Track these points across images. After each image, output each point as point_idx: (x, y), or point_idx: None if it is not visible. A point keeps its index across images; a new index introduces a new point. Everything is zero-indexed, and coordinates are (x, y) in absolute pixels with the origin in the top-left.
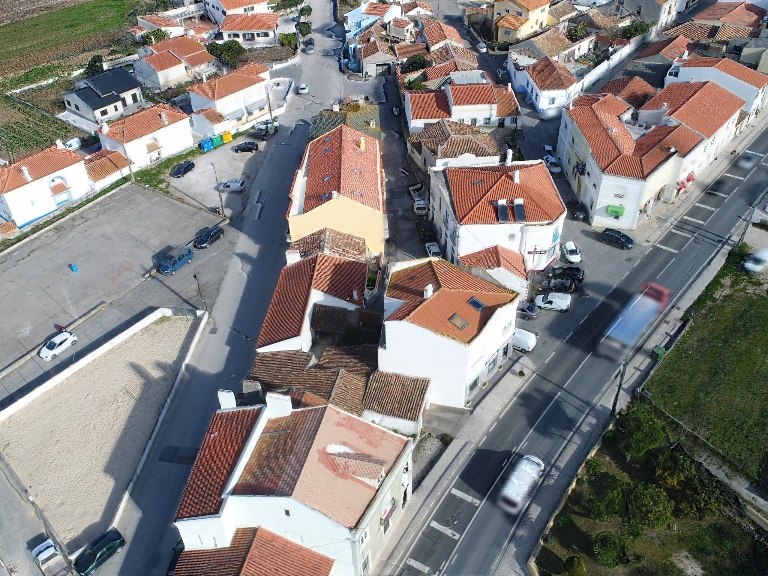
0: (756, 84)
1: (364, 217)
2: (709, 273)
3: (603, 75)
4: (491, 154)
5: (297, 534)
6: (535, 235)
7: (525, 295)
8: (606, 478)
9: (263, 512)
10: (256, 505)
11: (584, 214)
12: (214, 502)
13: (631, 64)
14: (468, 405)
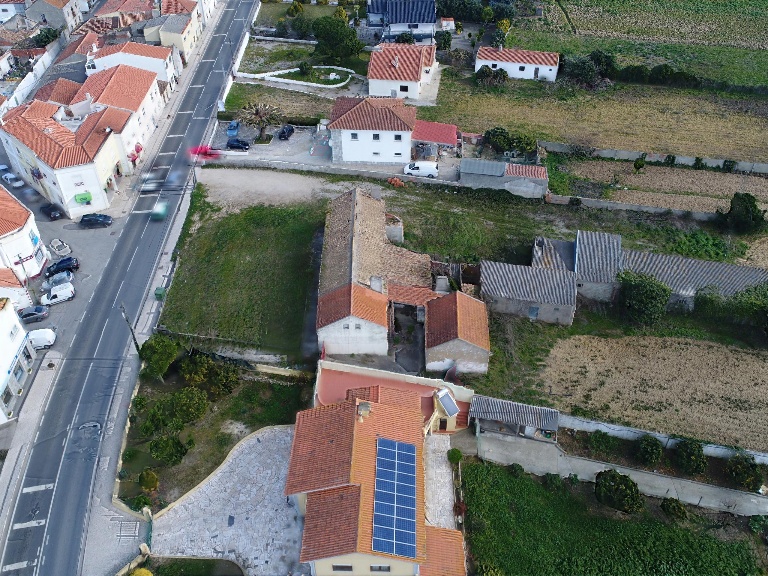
0: (161, 57)
1: None
2: (181, 217)
3: (34, 86)
4: None
5: None
6: (11, 245)
7: (29, 301)
8: (153, 405)
9: None
10: None
11: (59, 212)
12: None
13: (54, 69)
14: (11, 416)
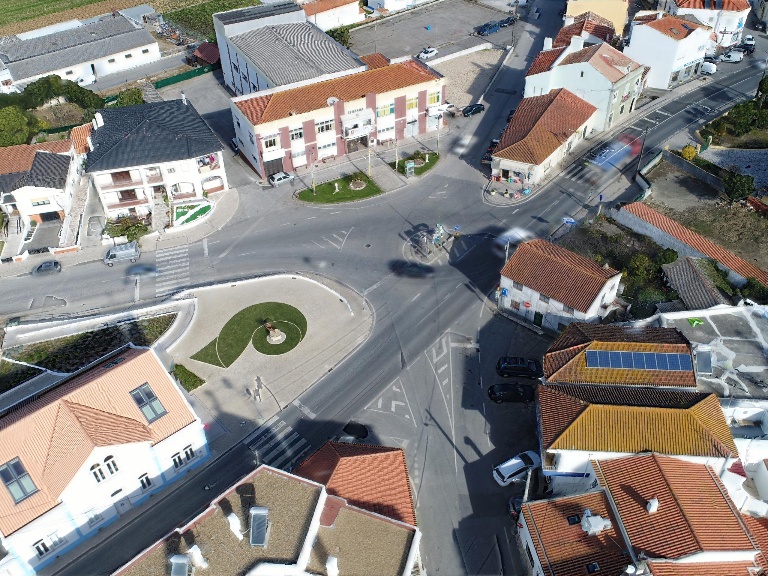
0: None
1: (616, 6)
2: None
3: None
4: None
5: (583, 90)
6: (727, 18)
7: (713, 53)
8: None
9: (569, 76)
10: (567, 71)
11: (763, 26)
12: (546, 69)
13: None
14: (670, 87)
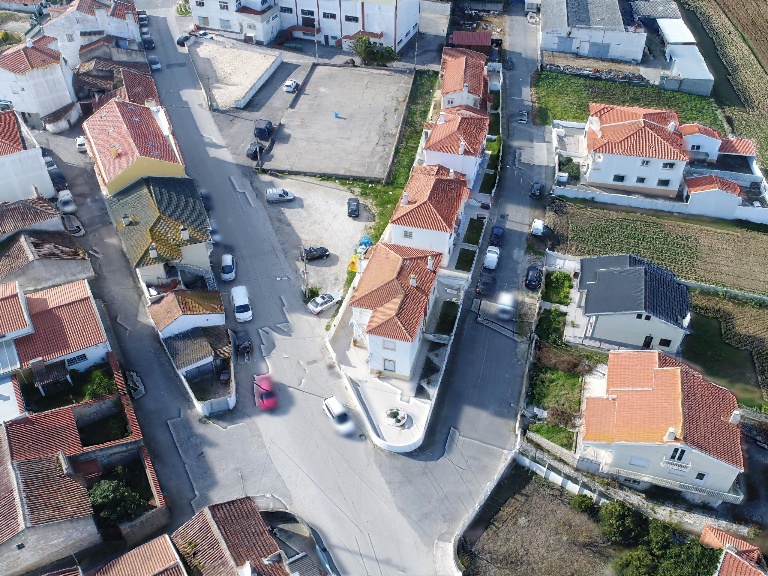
0: None
1: None
2: None
3: None
4: None
5: None
6: None
7: None
8: None
9: None
10: None
11: None
12: None
13: None
14: None
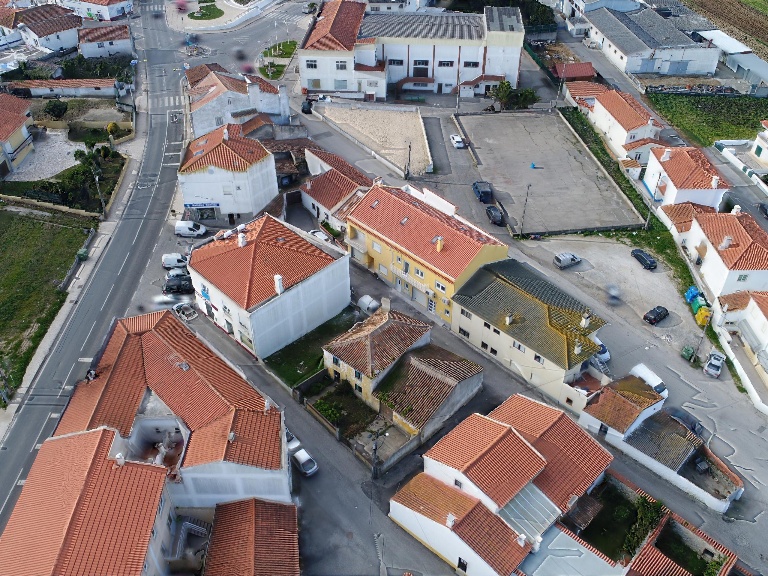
0: None
1: None
2: (45, 348)
3: None
4: (333, 341)
5: None
6: None
7: None
8: None
9: None
10: None
11: None
12: None
13: None
14: None
